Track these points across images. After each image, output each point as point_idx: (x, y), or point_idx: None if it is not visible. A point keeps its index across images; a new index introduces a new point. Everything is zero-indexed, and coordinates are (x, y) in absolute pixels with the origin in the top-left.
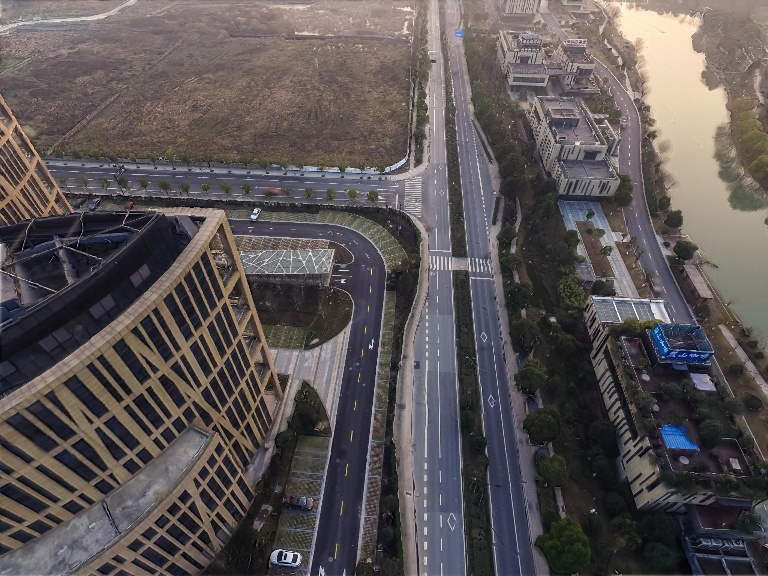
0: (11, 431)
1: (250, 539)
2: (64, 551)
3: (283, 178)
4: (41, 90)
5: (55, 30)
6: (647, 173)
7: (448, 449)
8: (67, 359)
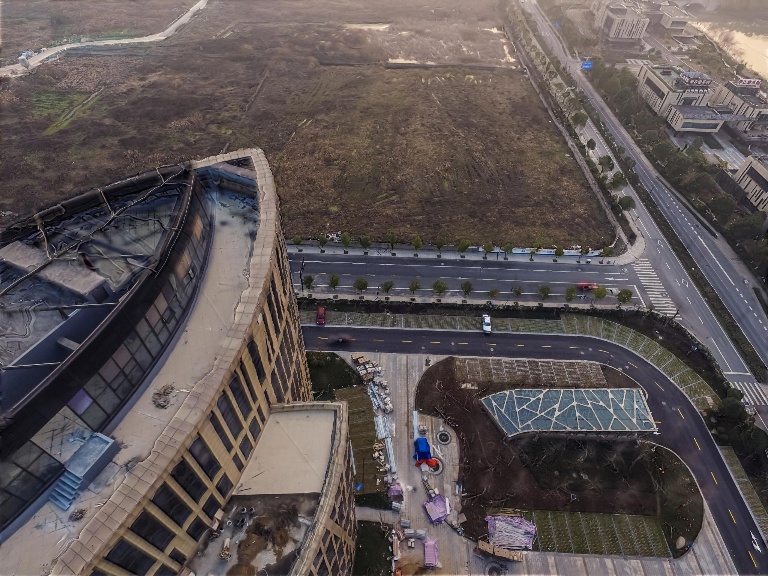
0: None
1: None
2: None
3: (485, 264)
4: (134, 139)
5: (112, 55)
6: None
7: None
8: None
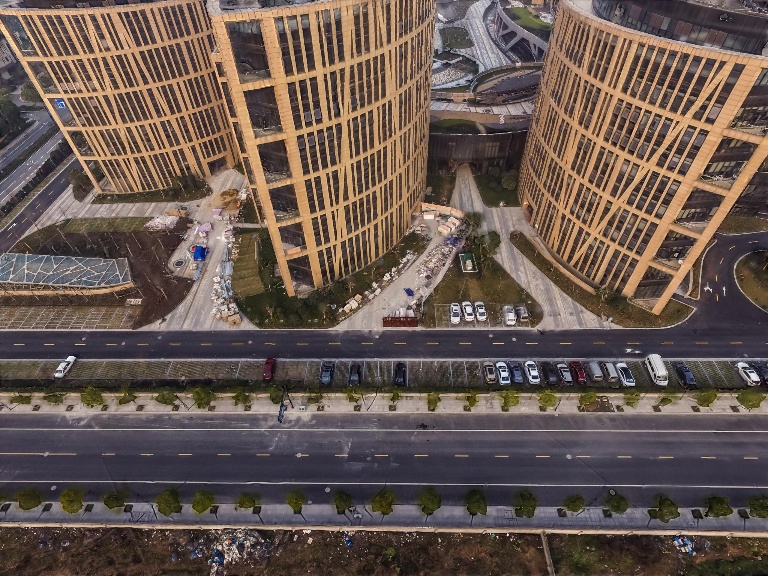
0: None
1: None
2: None
3: None
4: None
5: None
6: None
7: (7, 184)
8: None
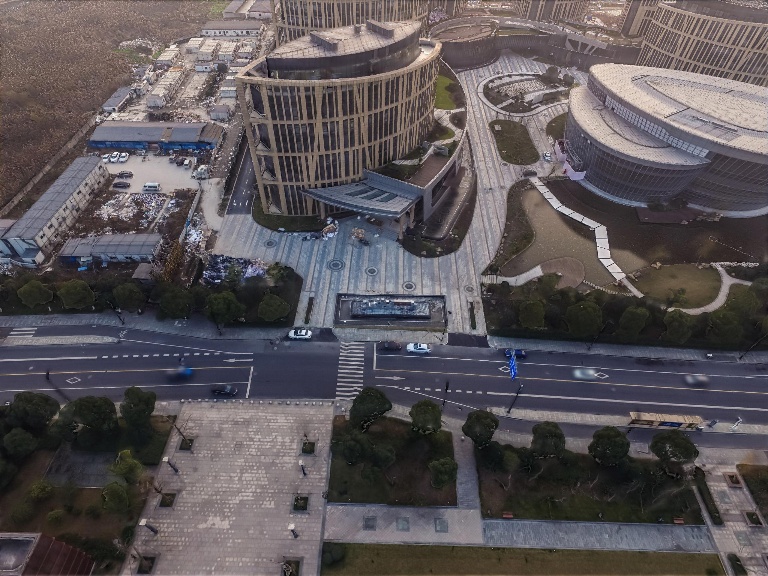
0: None
1: None
2: None
3: (592, 0)
4: None
5: None
6: None
7: None
8: None
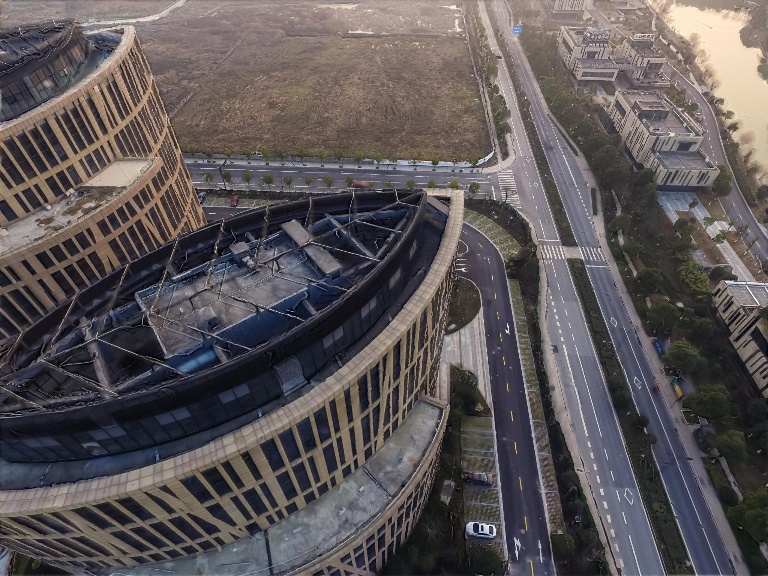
0: (356, 390)
1: (443, 512)
2: (344, 512)
3: (376, 172)
4: None
5: None
6: (735, 164)
7: (607, 428)
8: (393, 324)
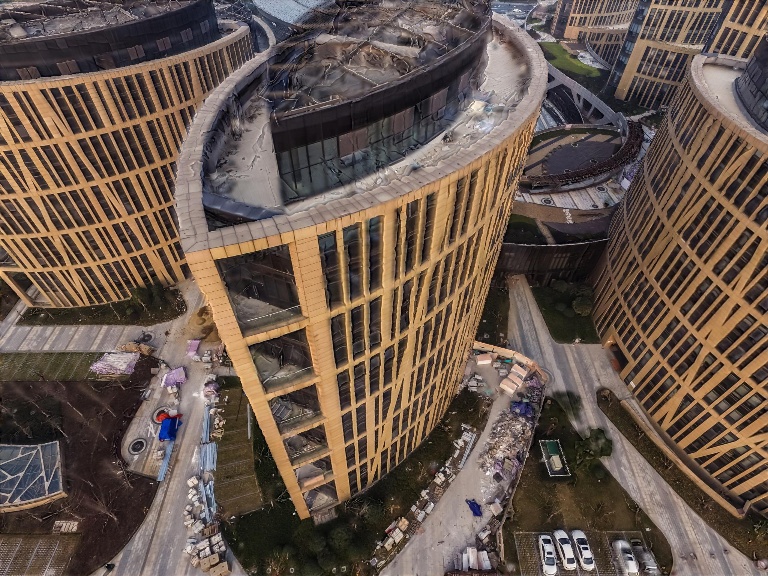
0: None
1: None
2: None
3: None
4: None
5: None
6: None
7: None
8: None
